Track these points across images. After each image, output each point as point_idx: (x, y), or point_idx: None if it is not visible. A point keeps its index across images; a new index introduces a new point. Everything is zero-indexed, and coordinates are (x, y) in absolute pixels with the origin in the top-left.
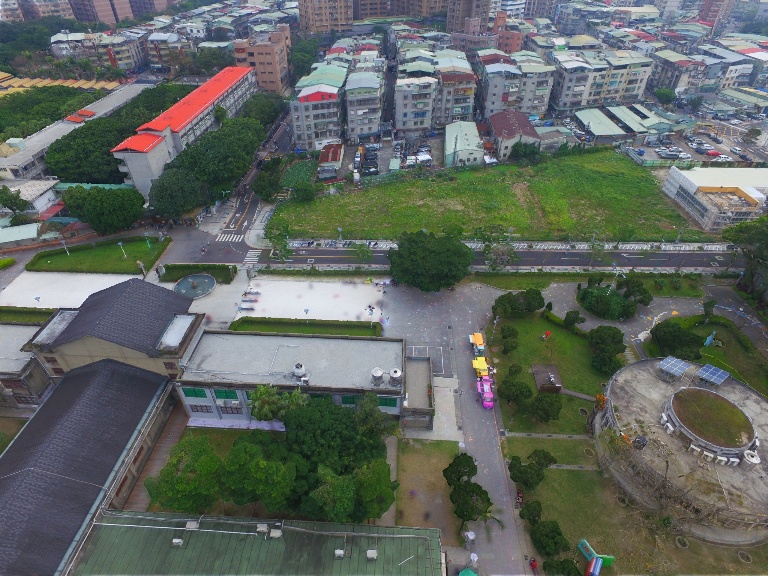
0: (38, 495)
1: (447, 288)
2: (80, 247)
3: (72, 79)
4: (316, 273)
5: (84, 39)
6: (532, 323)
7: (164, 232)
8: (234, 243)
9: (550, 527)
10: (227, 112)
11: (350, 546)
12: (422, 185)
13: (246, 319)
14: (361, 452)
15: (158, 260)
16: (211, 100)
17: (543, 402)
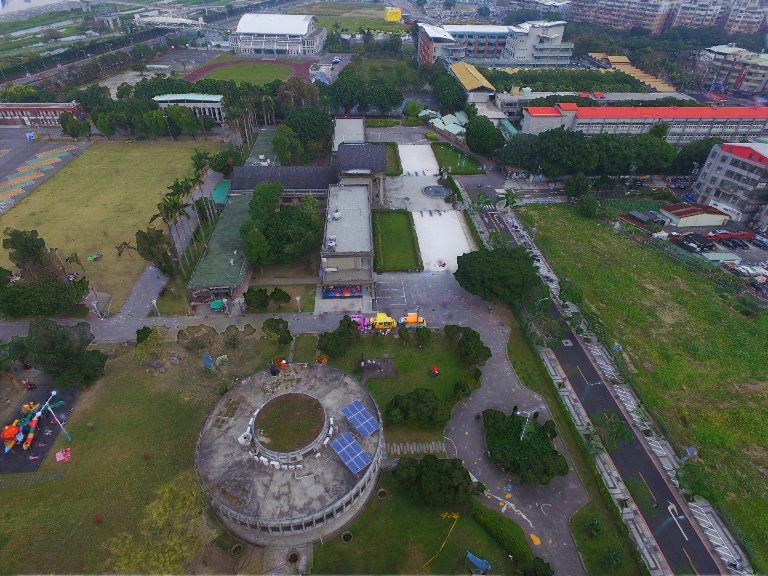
0: (270, 173)
1: (465, 289)
2: (458, 150)
3: (655, 76)
4: (474, 233)
5: (731, 53)
6: (456, 367)
7: (490, 168)
8: (496, 196)
9: (231, 327)
10: (682, 136)
11: (239, 257)
12: (697, 286)
13: (409, 213)
14: (280, 242)
15: (460, 175)
16: (662, 115)
17: (326, 332)
